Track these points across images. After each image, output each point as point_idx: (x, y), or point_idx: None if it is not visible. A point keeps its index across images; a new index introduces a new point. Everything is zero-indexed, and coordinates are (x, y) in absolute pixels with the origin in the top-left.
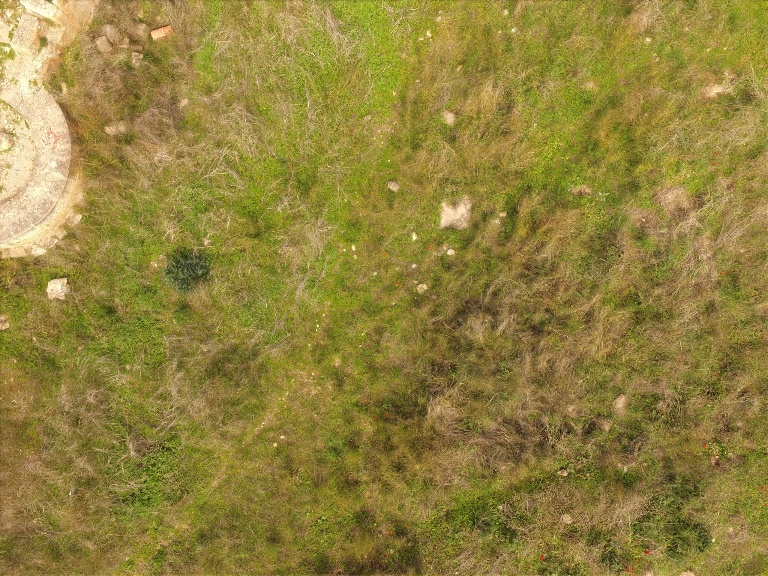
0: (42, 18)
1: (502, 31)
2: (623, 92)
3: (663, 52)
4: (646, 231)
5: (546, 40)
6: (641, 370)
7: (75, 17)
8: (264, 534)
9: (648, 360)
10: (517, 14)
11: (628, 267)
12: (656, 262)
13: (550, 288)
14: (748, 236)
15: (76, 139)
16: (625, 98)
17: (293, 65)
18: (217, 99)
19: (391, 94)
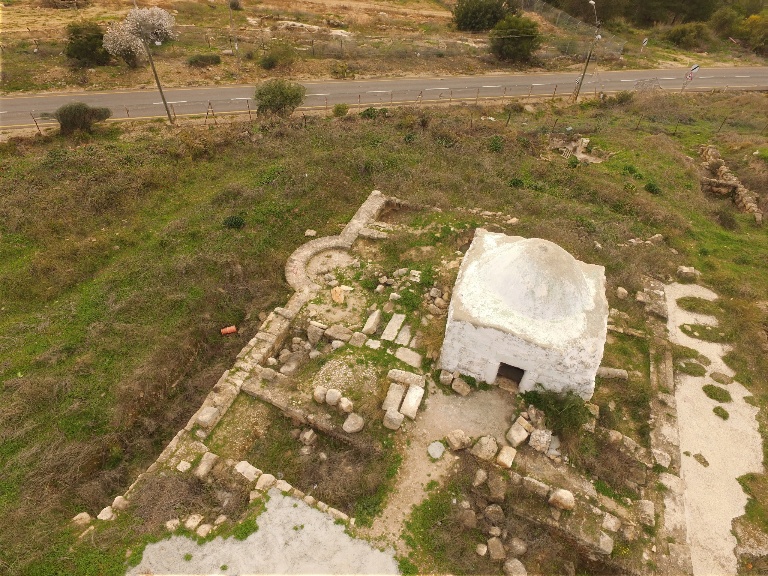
0: None
1: None
2: None
3: None
4: None
5: None
6: None
7: None
8: None
9: None
10: None
11: None
12: (4, 220)
13: None
14: None
15: None
16: None
17: None
18: None
19: None
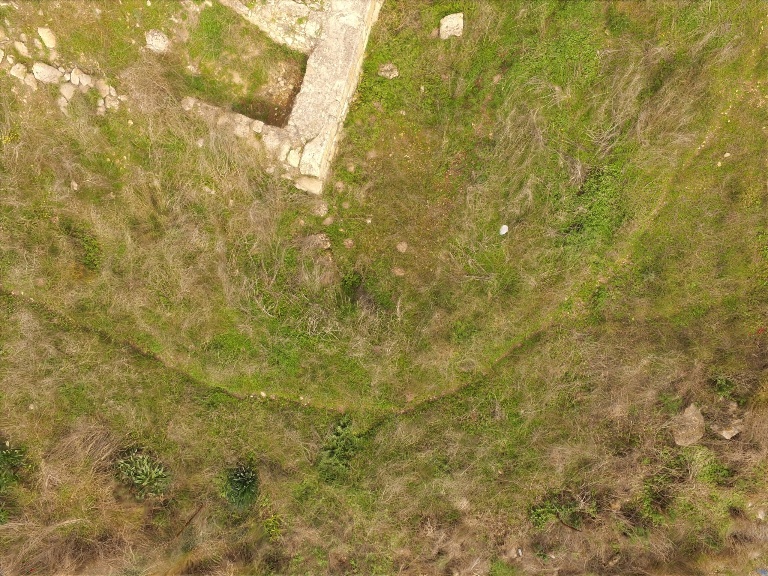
0: None
1: None
2: None
3: None
4: None
5: None
6: None
7: None
8: (711, 263)
9: None
10: None
11: None
12: None
13: None
14: None
15: None
16: None
17: None
18: None
19: None
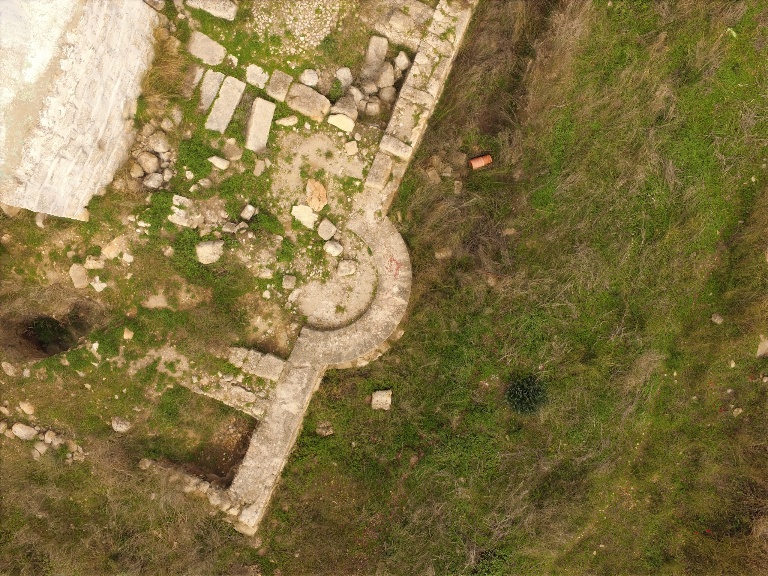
0: (392, 156)
1: None
2: None
3: None
4: None
5: None
6: None
7: None
8: None
9: None
10: None
11: None
12: None
13: None
14: None
15: None
16: None
17: (628, 206)
18: (560, 237)
19: (715, 233)
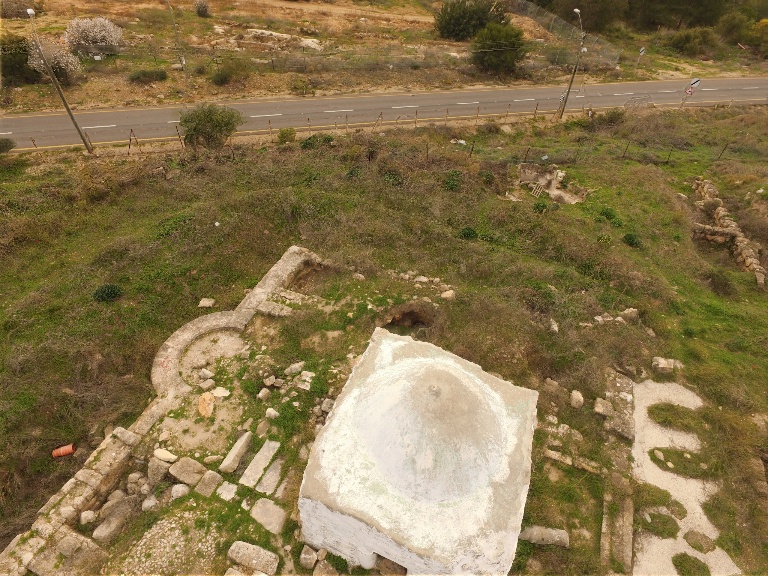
0: None
1: None
2: None
3: None
4: None
5: None
6: None
7: None
8: None
9: None
10: None
11: None
12: None
13: None
14: None
15: None
16: None
17: None
18: None
19: None
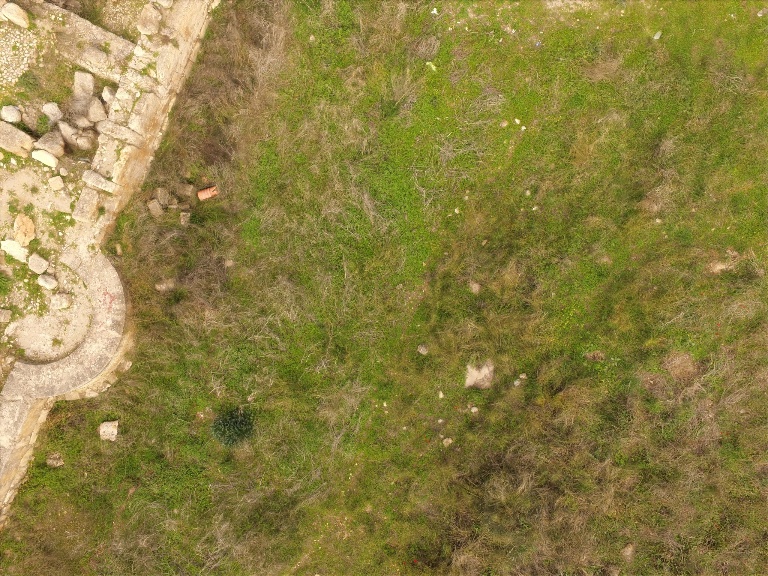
0: (101, 190)
1: (524, 209)
2: (634, 267)
3: (671, 231)
4: (654, 394)
5: (564, 218)
6: (647, 520)
7: (130, 185)
8: None
9: (654, 511)
10: (538, 197)
11: (637, 432)
12: (663, 425)
13: (566, 452)
14: (747, 399)
15: (129, 297)
16: (636, 273)
17: None
18: (262, 270)
19: (421, 265)
